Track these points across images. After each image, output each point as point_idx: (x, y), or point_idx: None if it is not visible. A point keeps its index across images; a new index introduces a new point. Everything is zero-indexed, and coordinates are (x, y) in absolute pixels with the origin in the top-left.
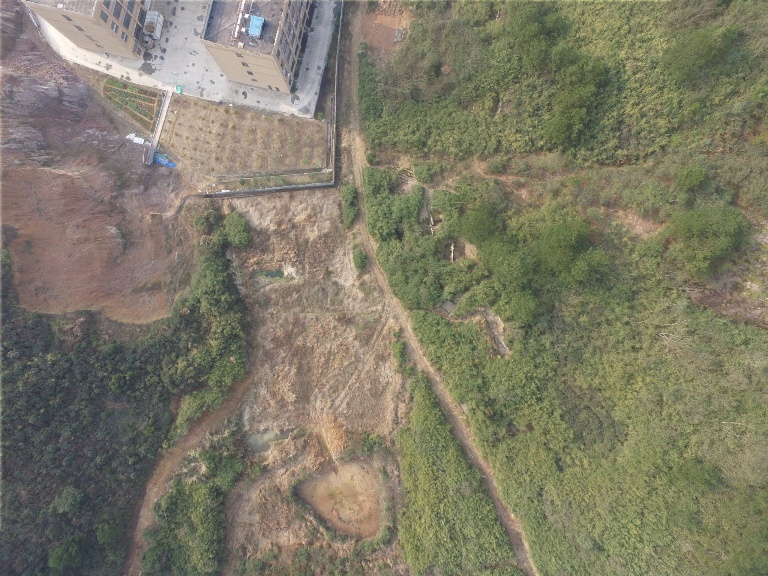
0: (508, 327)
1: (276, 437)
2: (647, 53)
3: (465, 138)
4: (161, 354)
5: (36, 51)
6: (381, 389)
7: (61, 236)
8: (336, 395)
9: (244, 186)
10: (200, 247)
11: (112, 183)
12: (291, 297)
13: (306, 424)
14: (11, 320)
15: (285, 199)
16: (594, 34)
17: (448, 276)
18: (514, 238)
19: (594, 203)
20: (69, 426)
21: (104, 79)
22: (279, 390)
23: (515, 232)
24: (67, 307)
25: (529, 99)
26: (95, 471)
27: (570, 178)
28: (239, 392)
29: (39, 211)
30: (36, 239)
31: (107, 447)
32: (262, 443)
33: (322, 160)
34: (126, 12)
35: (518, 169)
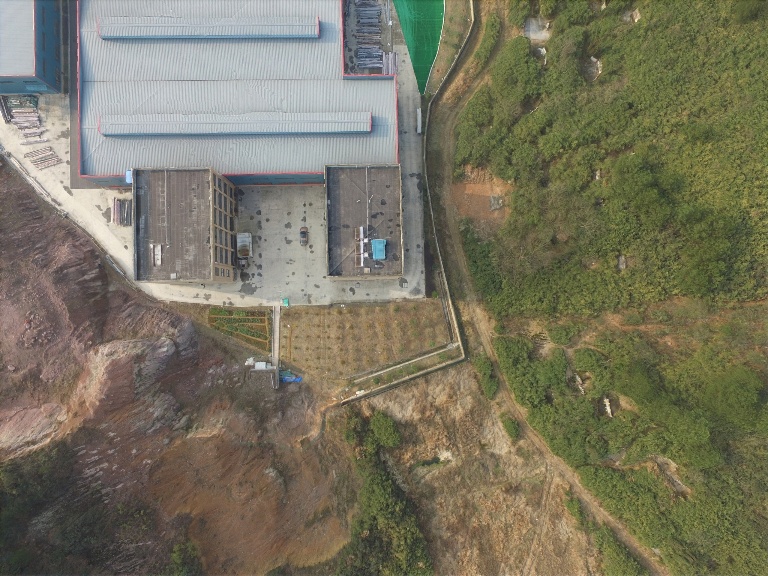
0: (687, 472)
1: None
2: None
3: (597, 298)
4: None
5: (130, 301)
6: (564, 546)
7: (228, 500)
8: (523, 565)
9: (378, 383)
10: (359, 462)
11: (253, 422)
12: (454, 481)
13: None
14: None
15: (421, 385)
16: (709, 185)
17: (612, 432)
18: (675, 390)
19: (750, 346)
20: None
21: (206, 310)
22: (467, 575)
23: (676, 385)
24: (256, 571)
25: (655, 254)
26: None
27: (713, 320)
28: None
29: (200, 482)
30: (207, 513)
31: None
32: None
33: (446, 336)
34: None
35: (658, 320)
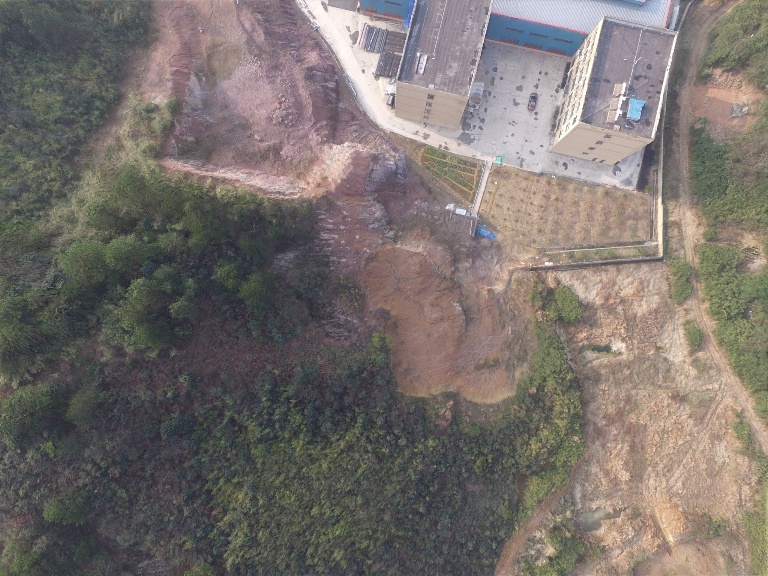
0: None
1: (607, 516)
2: None
3: None
4: (512, 434)
5: (355, 120)
6: (717, 469)
7: (419, 315)
8: (671, 474)
9: (569, 259)
10: (539, 324)
11: (449, 258)
12: (621, 373)
13: (638, 503)
14: (397, 406)
15: (611, 273)
16: None
17: None
18: None
19: None
20: (446, 512)
21: (421, 148)
22: (612, 468)
23: None
24: (430, 388)
25: None
26: (467, 557)
27: None
28: (572, 470)
29: (399, 290)
30: (400, 319)
31: (472, 532)
32: (592, 521)
33: (646, 233)
34: None
35: None
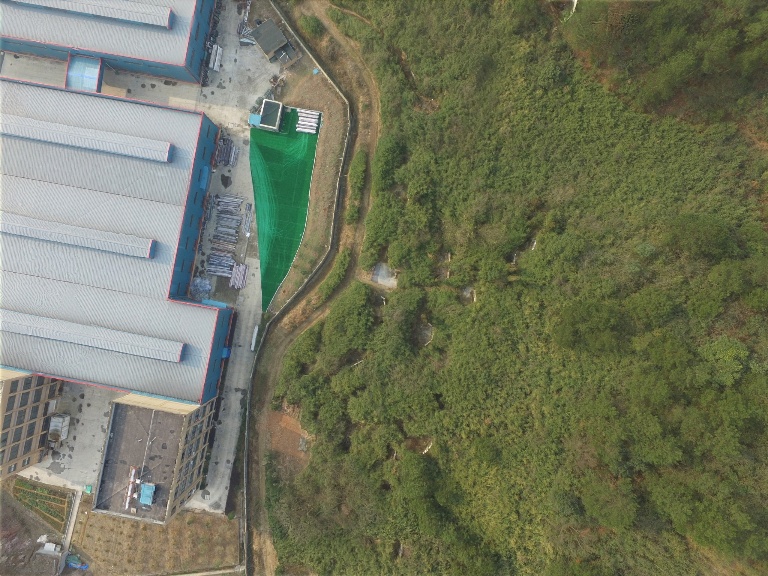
0: None
1: None
2: (536, 547)
3: None
4: None
5: None
6: None
7: None
8: None
9: None
10: None
11: None
12: None
13: None
14: None
15: None
16: (485, 510)
17: None
18: None
19: None
20: None
21: (13, 479)
22: None
23: None
24: None
25: (427, 557)
26: None
27: None
28: None
29: None
30: None
31: None
32: None
33: (235, 558)
34: (26, 440)
35: None
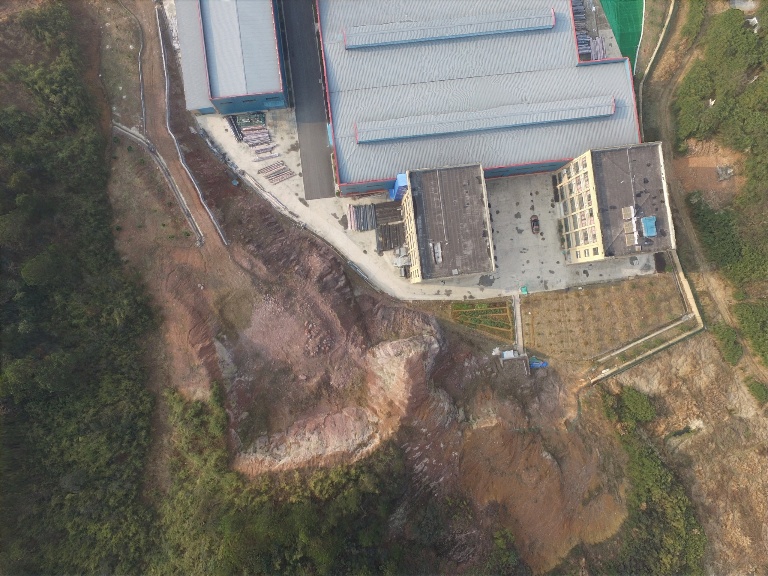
0: None
1: None
2: None
3: None
4: None
5: (376, 303)
6: None
7: (520, 485)
8: None
9: None
10: (624, 438)
11: (519, 409)
12: (708, 448)
13: (765, 559)
14: None
15: (665, 358)
16: None
17: None
18: None
19: None
20: None
21: (448, 306)
22: (732, 539)
23: None
24: (556, 551)
25: None
26: None
27: None
28: None
29: (493, 470)
30: (505, 499)
31: None
32: None
33: (681, 309)
34: None
35: None
